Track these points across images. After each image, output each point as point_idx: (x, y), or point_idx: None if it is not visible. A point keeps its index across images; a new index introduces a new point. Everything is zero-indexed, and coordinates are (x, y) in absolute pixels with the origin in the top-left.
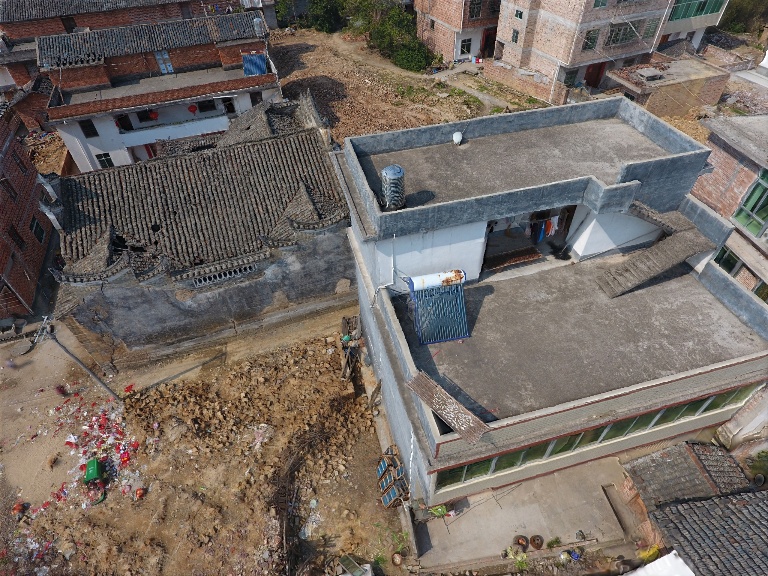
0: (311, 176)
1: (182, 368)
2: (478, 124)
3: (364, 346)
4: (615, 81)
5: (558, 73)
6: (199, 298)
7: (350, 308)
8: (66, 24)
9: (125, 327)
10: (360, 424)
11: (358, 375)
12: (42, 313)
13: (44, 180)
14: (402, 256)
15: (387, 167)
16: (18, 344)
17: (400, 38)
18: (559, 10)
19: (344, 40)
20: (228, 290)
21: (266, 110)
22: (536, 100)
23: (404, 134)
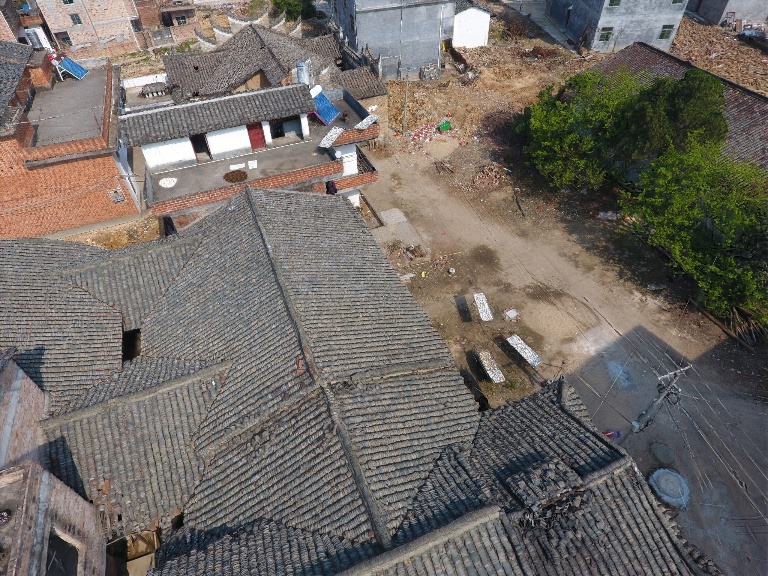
0: None
1: None
2: None
3: None
4: None
5: (132, 27)
6: None
7: None
8: None
9: None
10: None
11: None
12: None
13: None
14: None
15: None
16: None
17: None
18: None
19: None
20: None
21: None
22: None
23: None
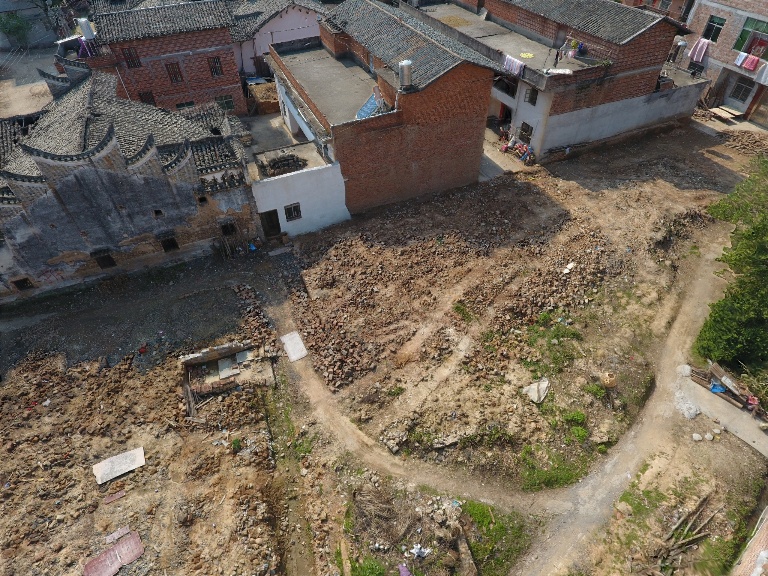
0: None
1: None
2: None
3: None
4: None
5: None
6: None
7: None
8: (482, 1)
9: None
10: None
11: None
12: None
13: None
14: None
15: None
16: None
17: None
18: None
19: None
20: None
21: None
22: None
23: None
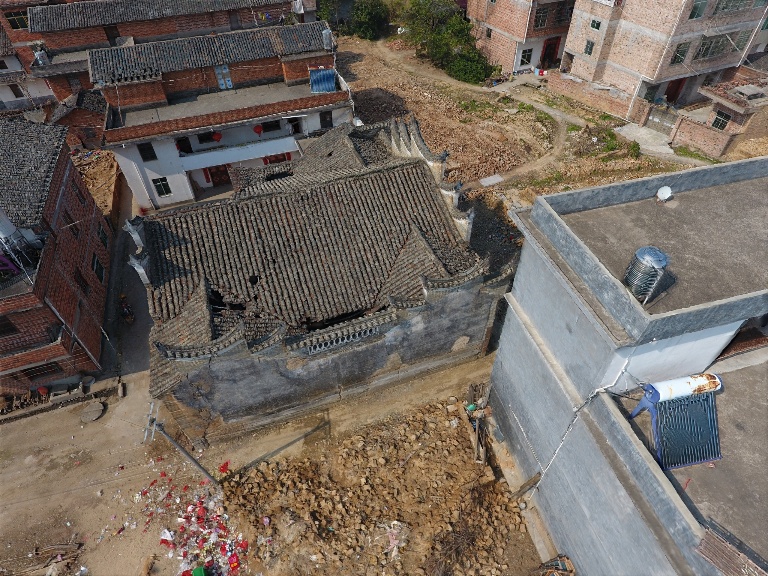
0: (422, 217)
1: (282, 441)
2: (688, 177)
3: (490, 416)
4: (694, 96)
5: (639, 88)
6: (310, 365)
7: (462, 366)
8: (108, 33)
9: (226, 400)
10: (507, 520)
11: (491, 454)
12: (110, 368)
13: (132, 227)
14: (639, 356)
15: (641, 250)
16: (88, 407)
17: (456, 48)
18: (646, 21)
19: (390, 48)
20: (342, 355)
21: (348, 134)
22: (611, 116)
23: (604, 190)
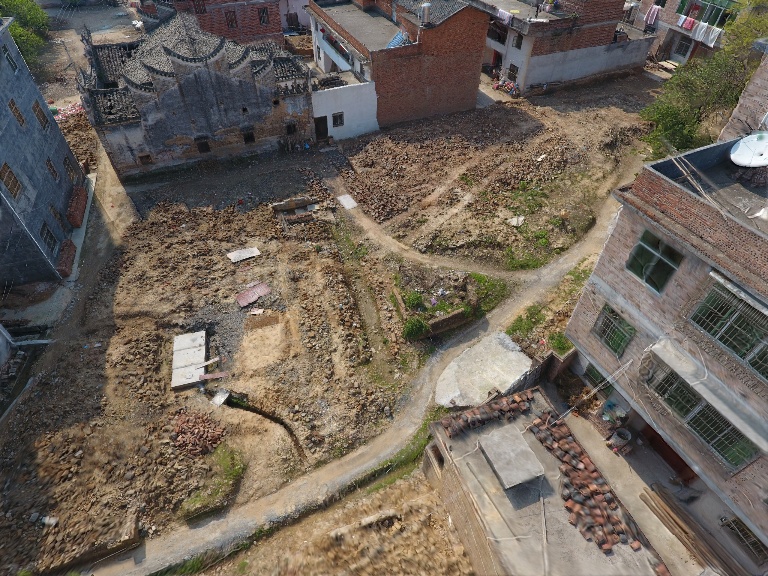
0: None
1: None
2: None
3: None
4: (712, 521)
5: None
6: None
7: None
8: None
9: None
10: None
11: None
12: None
13: None
14: None
15: None
16: None
17: None
18: None
19: None
20: None
21: None
22: (567, 349)
23: None
